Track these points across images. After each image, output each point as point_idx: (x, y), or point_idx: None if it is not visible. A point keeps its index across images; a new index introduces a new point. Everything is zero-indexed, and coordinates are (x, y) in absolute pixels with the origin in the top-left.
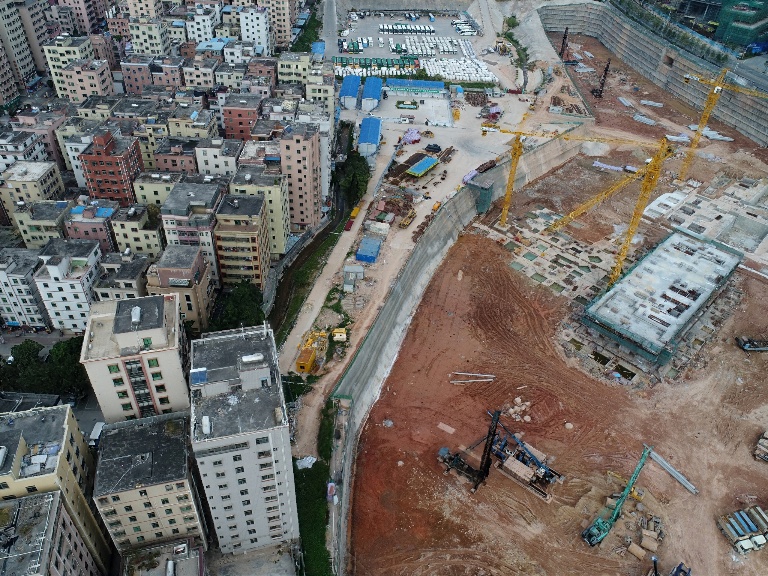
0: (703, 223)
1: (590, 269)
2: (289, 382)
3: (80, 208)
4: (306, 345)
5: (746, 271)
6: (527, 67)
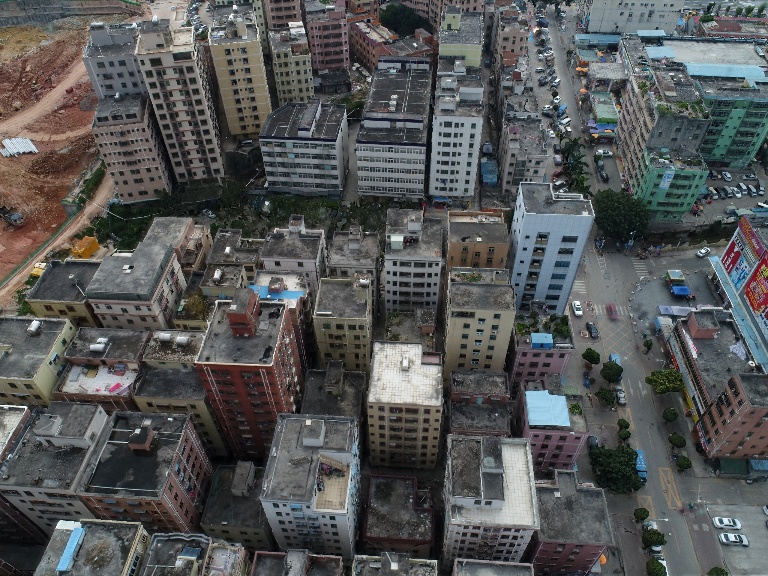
0: None
1: None
2: None
3: (294, 297)
4: None
5: None
6: None
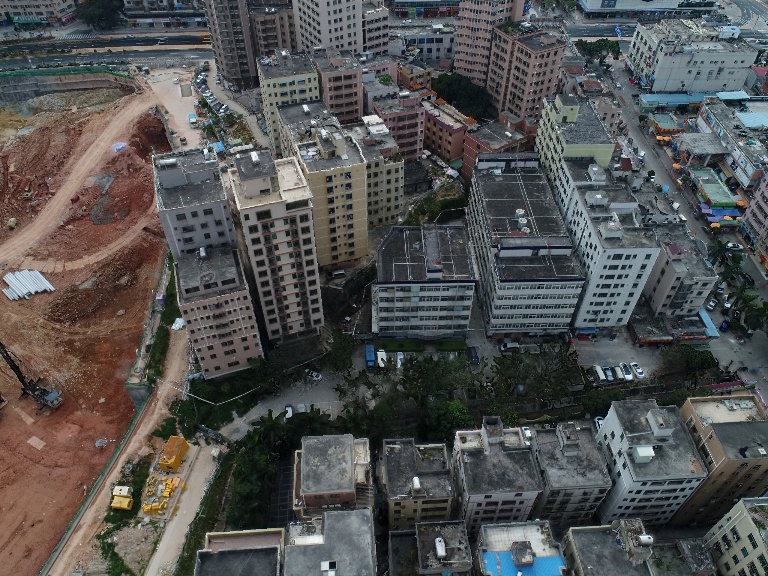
0: None
1: None
2: (191, 394)
3: (553, 571)
4: (173, 484)
5: None
6: None
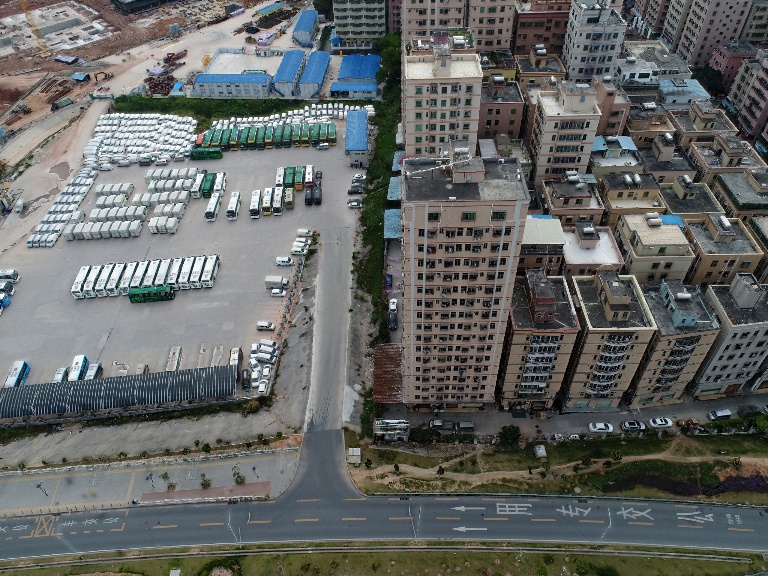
0: (77, 31)
1: (192, 7)
2: None
3: None
4: None
5: (98, 8)
6: (0, 175)
